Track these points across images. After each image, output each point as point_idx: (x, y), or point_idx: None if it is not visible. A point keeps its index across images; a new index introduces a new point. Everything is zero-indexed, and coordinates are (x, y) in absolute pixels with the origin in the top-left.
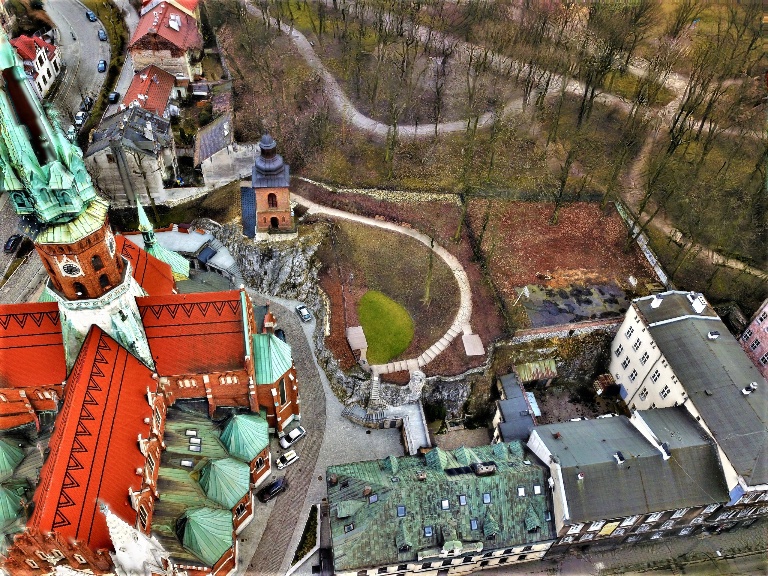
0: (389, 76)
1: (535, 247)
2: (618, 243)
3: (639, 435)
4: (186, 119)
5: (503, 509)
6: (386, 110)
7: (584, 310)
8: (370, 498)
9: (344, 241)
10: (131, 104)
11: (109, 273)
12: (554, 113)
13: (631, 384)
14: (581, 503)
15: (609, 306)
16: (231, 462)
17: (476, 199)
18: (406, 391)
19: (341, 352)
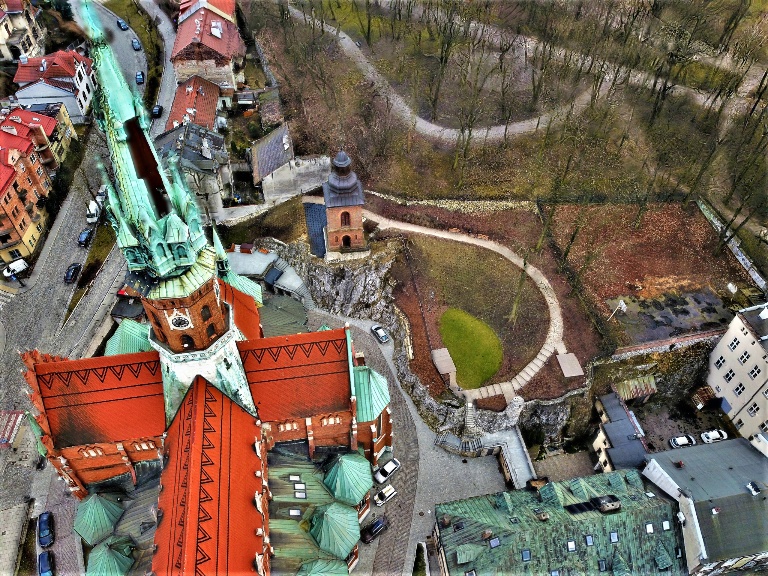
0: (452, 78)
1: (620, 254)
2: (706, 246)
3: (766, 460)
4: (234, 131)
5: (632, 548)
6: (446, 113)
7: (682, 322)
8: (491, 542)
9: (419, 257)
10: (185, 121)
11: (215, 322)
12: (631, 110)
13: (737, 398)
14: (717, 540)
15: (708, 316)
16: (339, 507)
17: (553, 205)
18: (503, 417)
19: (429, 377)
